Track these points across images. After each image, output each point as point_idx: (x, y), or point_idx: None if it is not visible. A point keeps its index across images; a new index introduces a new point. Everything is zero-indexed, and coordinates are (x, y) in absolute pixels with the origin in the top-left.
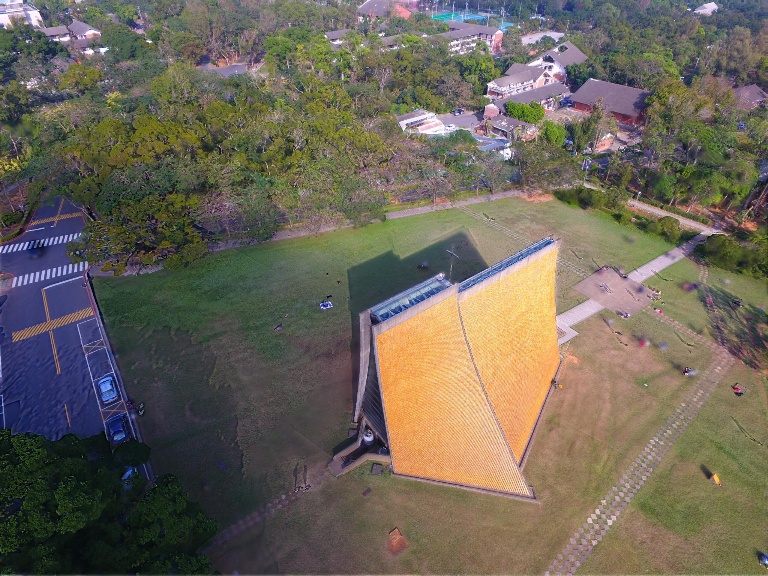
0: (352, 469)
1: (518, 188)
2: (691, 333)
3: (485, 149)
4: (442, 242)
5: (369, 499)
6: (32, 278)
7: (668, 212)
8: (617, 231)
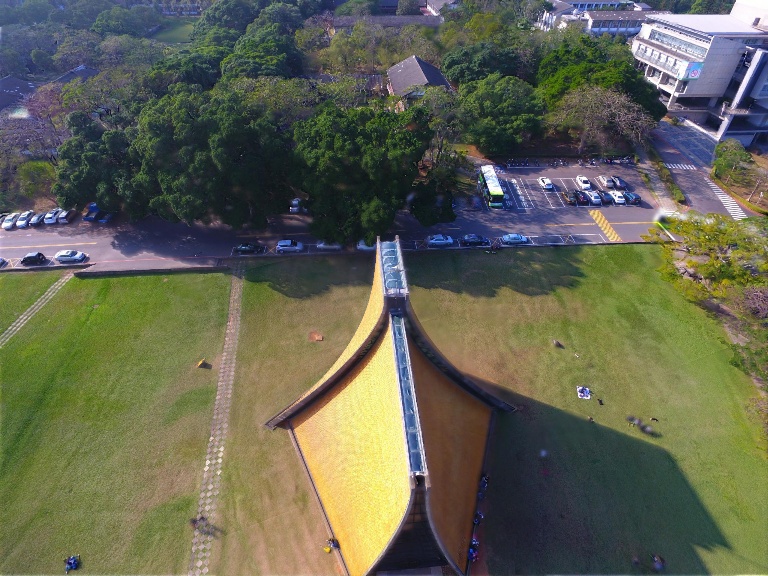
0: None
1: None
2: None
3: None
4: None
5: (350, 335)
6: None
7: None
8: None
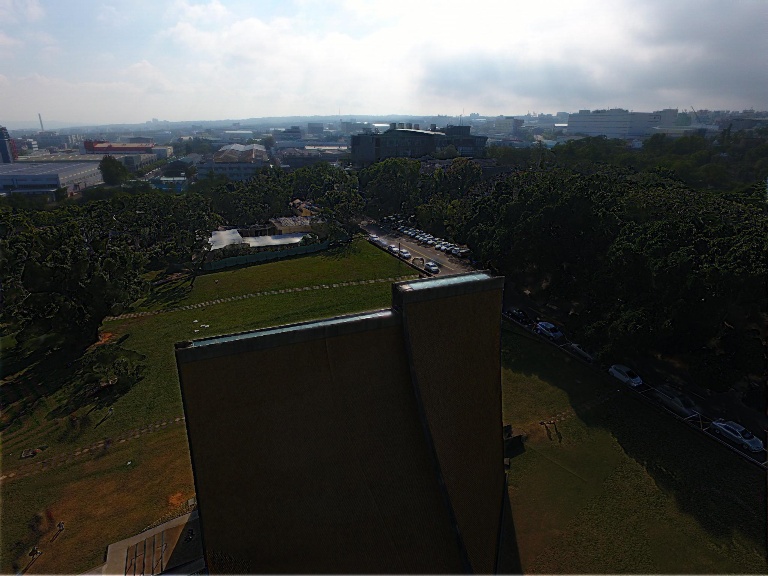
0: None
1: None
2: None
3: None
4: None
5: None
6: None
7: None
8: None
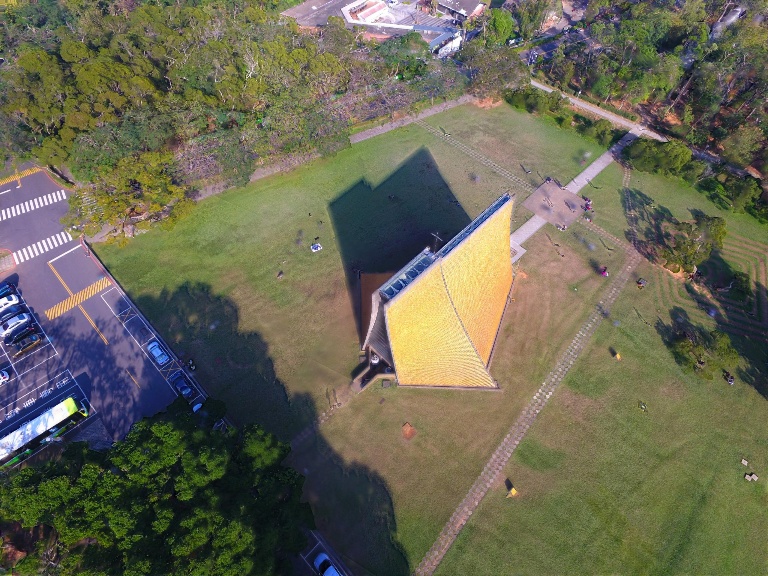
0: (368, 386)
1: (470, 92)
2: (612, 238)
3: (434, 43)
4: (406, 166)
5: (385, 406)
6: (31, 252)
7: (603, 109)
8: (559, 137)
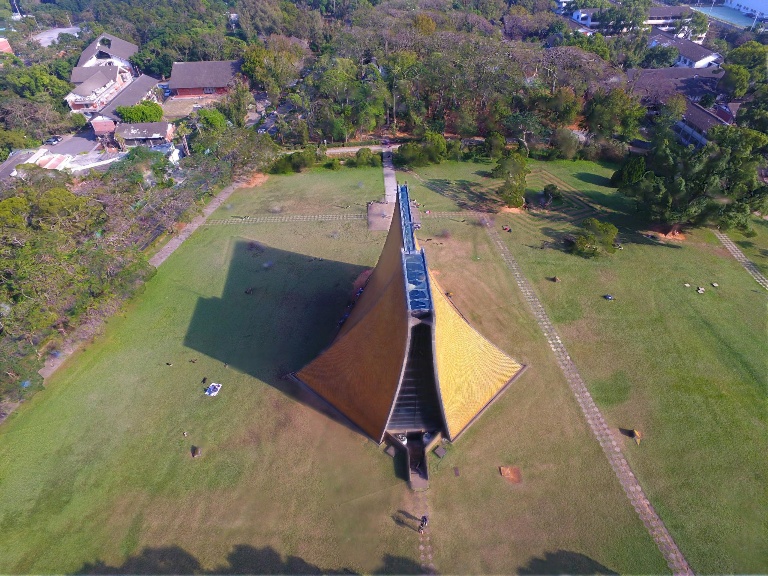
0: None
1: (230, 181)
2: (456, 214)
3: None
4: (234, 260)
5: (464, 474)
6: None
7: (350, 147)
8: (341, 176)
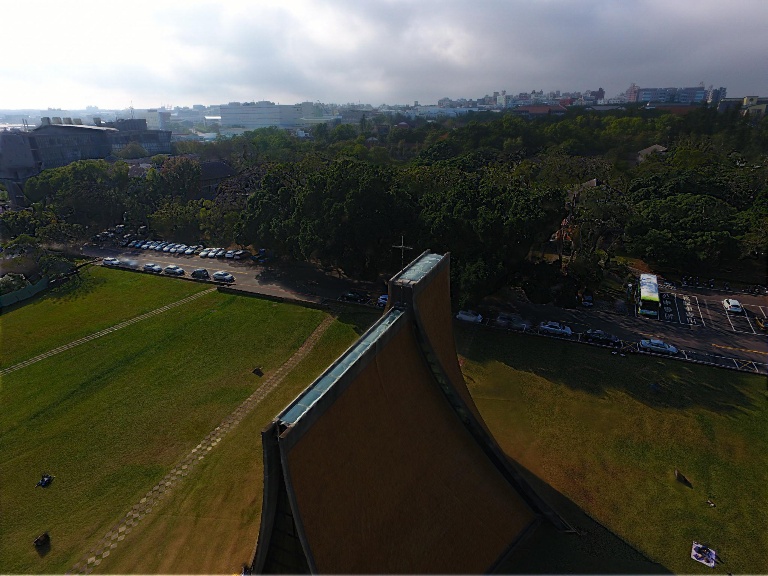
0: None
1: None
2: None
3: None
4: None
5: None
6: None
7: None
8: None
